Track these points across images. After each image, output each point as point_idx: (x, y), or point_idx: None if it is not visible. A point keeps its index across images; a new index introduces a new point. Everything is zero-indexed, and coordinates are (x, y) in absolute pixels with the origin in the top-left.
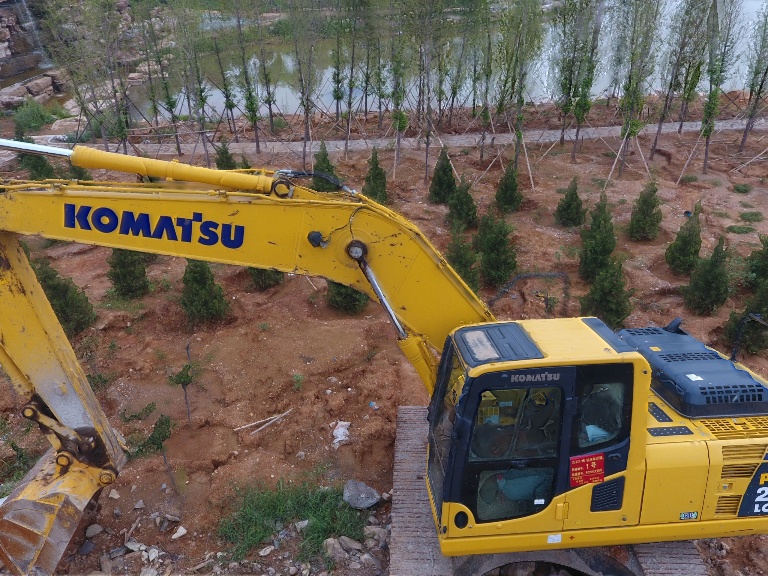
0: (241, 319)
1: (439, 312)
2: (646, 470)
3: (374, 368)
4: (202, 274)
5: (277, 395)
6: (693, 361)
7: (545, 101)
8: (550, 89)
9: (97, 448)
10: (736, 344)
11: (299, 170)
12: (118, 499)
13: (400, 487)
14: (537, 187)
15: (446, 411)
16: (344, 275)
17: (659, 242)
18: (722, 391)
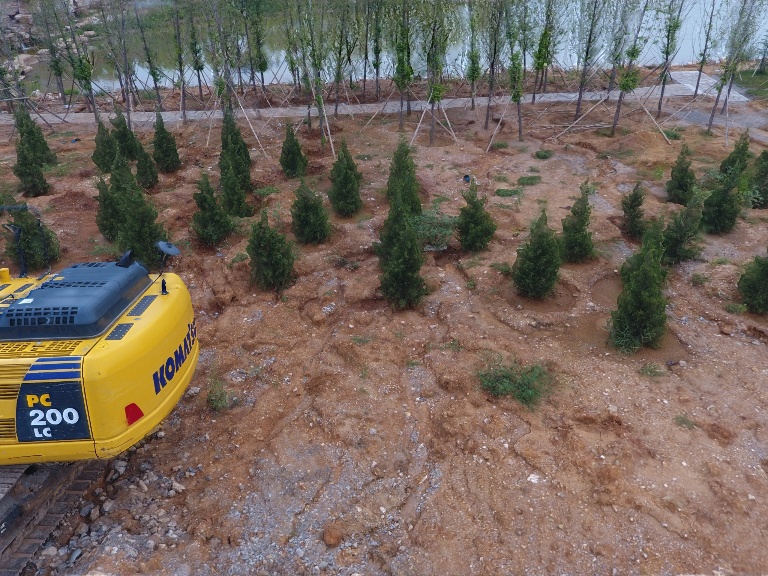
0: None
1: None
2: None
3: None
4: None
5: None
6: (63, 288)
7: None
8: (390, 57)
9: None
10: (389, 298)
11: None
12: None
13: None
14: None
15: None
16: None
17: None
18: (30, 313)
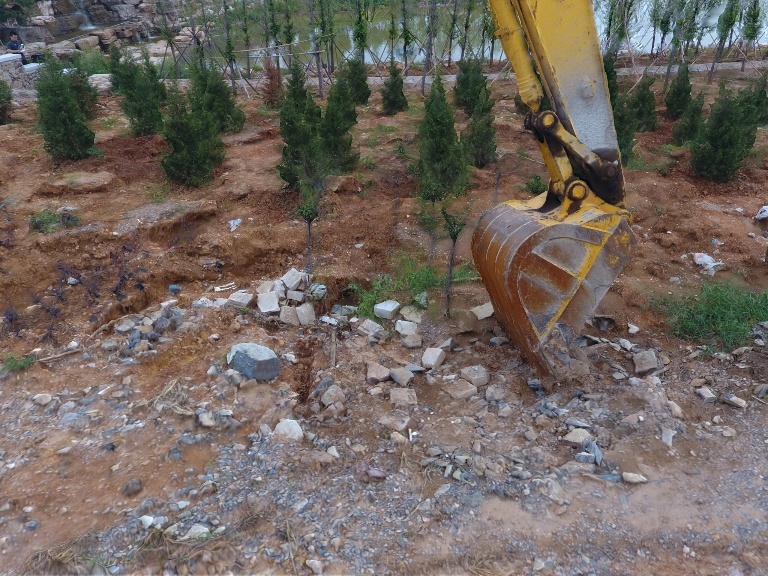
0: (484, 184)
1: None
2: None
3: (688, 212)
4: (449, 128)
5: None
6: None
7: (626, 51)
8: None
9: (615, 178)
10: None
11: (418, 95)
12: None
13: None
14: None
15: None
16: None
17: None
18: None
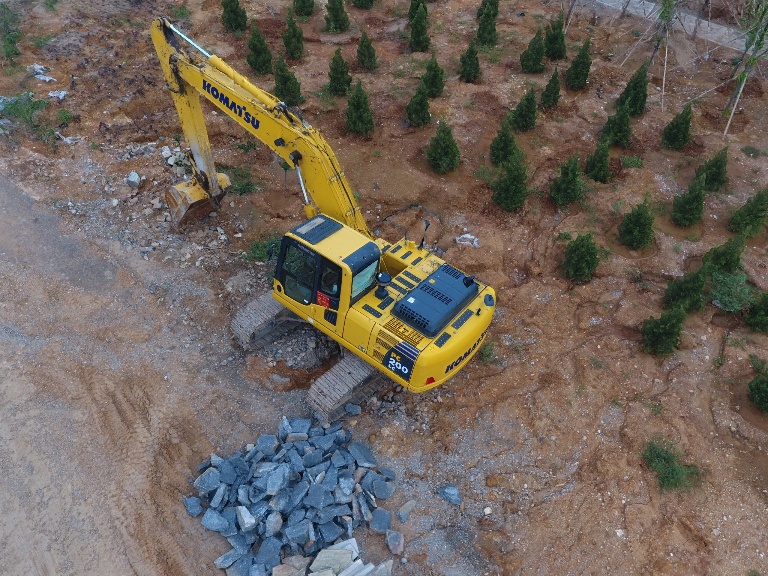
0: (373, 141)
1: (327, 202)
2: (346, 317)
3: (399, 213)
4: (359, 103)
5: None
6: (430, 296)
7: None
8: None
9: (206, 182)
10: None
11: None
12: (232, 207)
13: None
14: (734, 135)
15: None
16: None
17: (752, 242)
18: (410, 312)
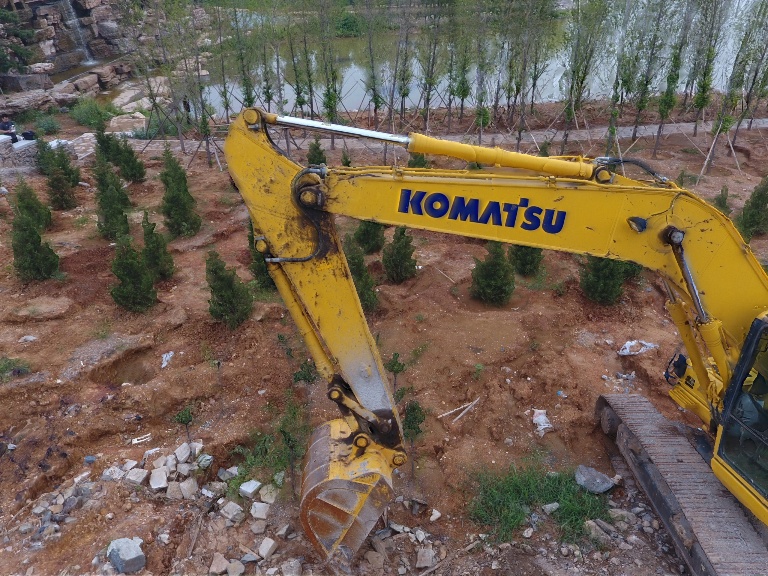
0: (392, 311)
1: (736, 297)
2: None
3: (549, 358)
4: (358, 266)
5: (459, 384)
6: None
7: (598, 98)
8: (625, 86)
9: (392, 430)
10: None
11: None
12: None
13: (668, 470)
14: None
15: (744, 394)
16: (653, 260)
17: None
18: None
